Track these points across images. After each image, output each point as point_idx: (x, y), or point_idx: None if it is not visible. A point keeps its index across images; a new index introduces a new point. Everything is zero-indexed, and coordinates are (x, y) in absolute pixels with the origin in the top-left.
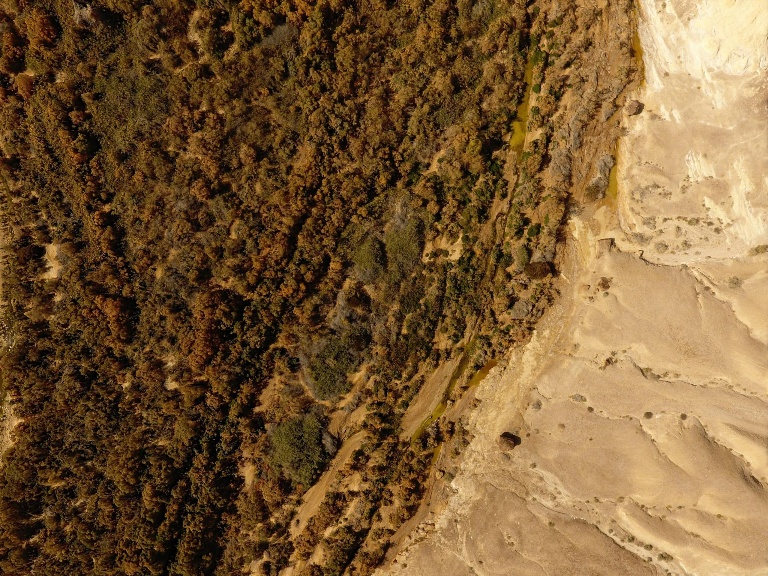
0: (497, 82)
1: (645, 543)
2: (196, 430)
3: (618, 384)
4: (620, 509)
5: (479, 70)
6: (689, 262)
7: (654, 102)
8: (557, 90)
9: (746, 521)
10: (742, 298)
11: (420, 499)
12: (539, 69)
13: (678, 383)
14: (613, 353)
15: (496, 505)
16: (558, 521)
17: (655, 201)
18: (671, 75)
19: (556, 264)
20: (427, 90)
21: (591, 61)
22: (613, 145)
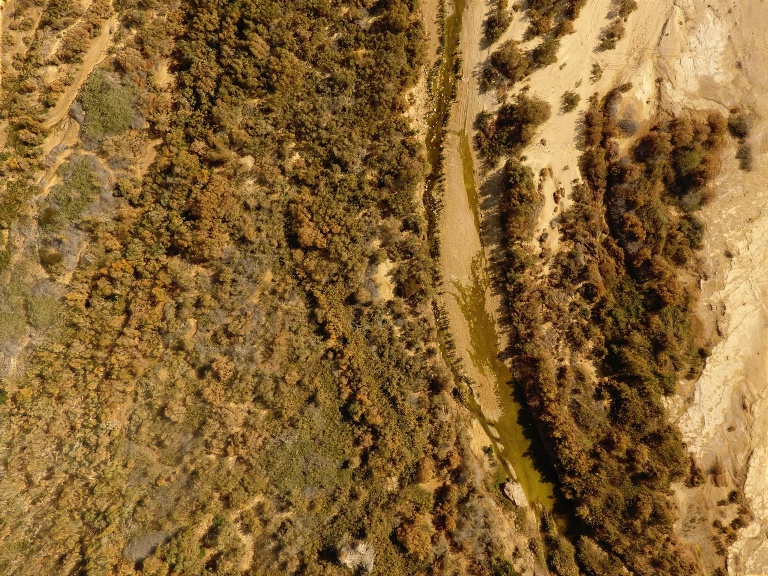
0: None
1: None
2: None
3: None
4: None
5: None
6: None
7: None
8: None
9: None
10: None
11: None
12: None
13: None
14: None
15: None
16: None
17: None
18: None
19: None
20: None
21: None
22: None
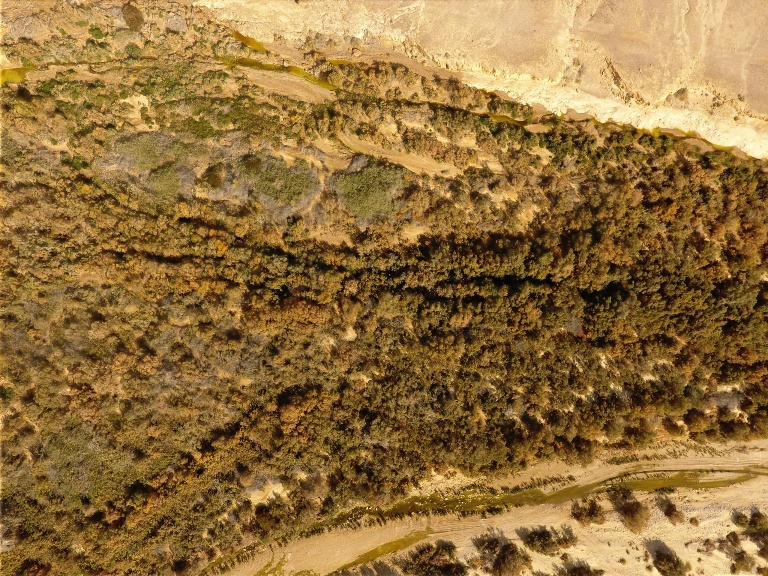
0: None
1: None
2: None
3: None
4: None
5: None
6: None
7: None
8: None
9: None
10: None
11: None
12: None
13: None
14: None
15: None
16: None
17: None
18: None
19: (123, 4)
20: None
21: None
22: None
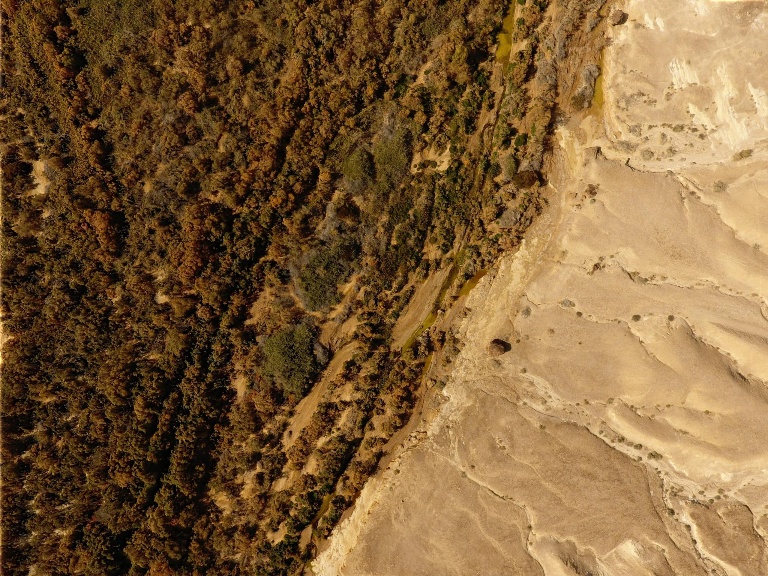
0: None
1: (635, 443)
2: (187, 342)
3: (606, 288)
4: (610, 410)
5: None
6: (674, 168)
7: (638, 11)
8: (542, 0)
9: (733, 415)
10: (727, 201)
11: (412, 408)
12: None
13: (665, 285)
14: (601, 258)
15: (487, 410)
16: (549, 424)
17: (640, 109)
18: None
19: (543, 173)
20: (413, 0)
21: None
22: (598, 55)
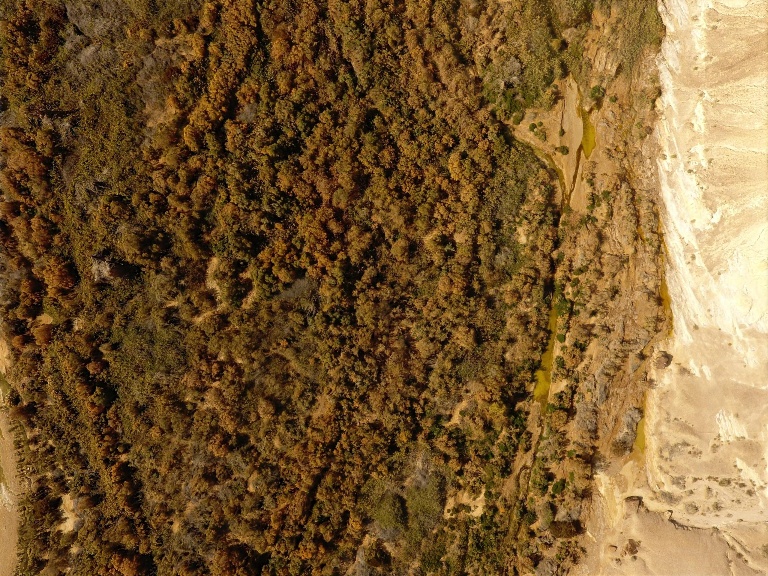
0: (521, 333)
1: None
2: None
3: None
4: None
5: (502, 320)
6: (720, 525)
7: (683, 355)
8: (582, 343)
9: None
10: None
11: None
12: (564, 321)
13: None
14: None
15: None
16: None
17: (684, 460)
18: (701, 329)
19: (582, 522)
20: (449, 346)
21: (617, 310)
22: (640, 397)
